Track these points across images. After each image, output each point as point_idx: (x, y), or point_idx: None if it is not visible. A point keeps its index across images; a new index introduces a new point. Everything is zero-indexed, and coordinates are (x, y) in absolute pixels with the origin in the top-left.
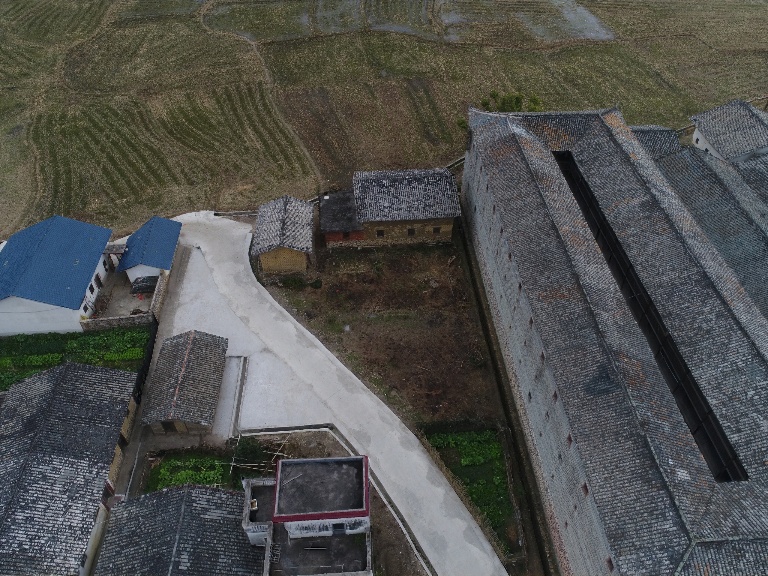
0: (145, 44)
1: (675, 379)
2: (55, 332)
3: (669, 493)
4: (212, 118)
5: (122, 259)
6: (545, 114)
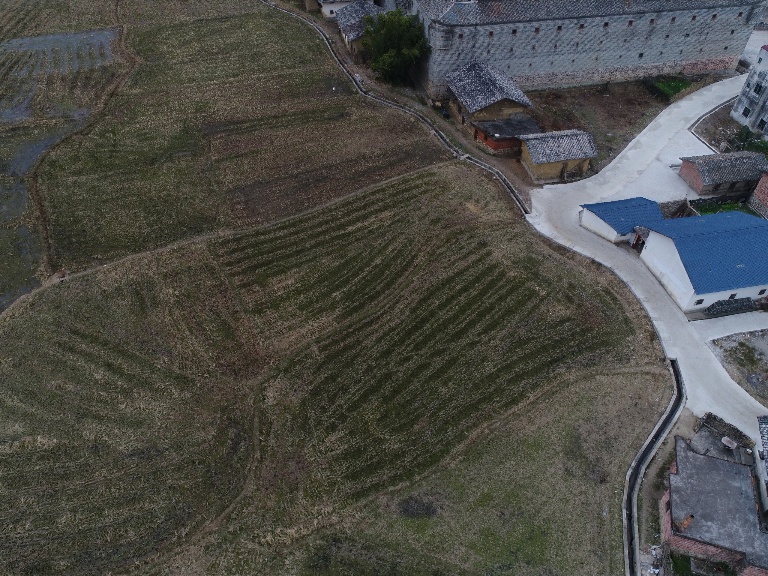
0: (5, 451)
1: None
2: None
3: None
4: (328, 266)
5: None
6: None
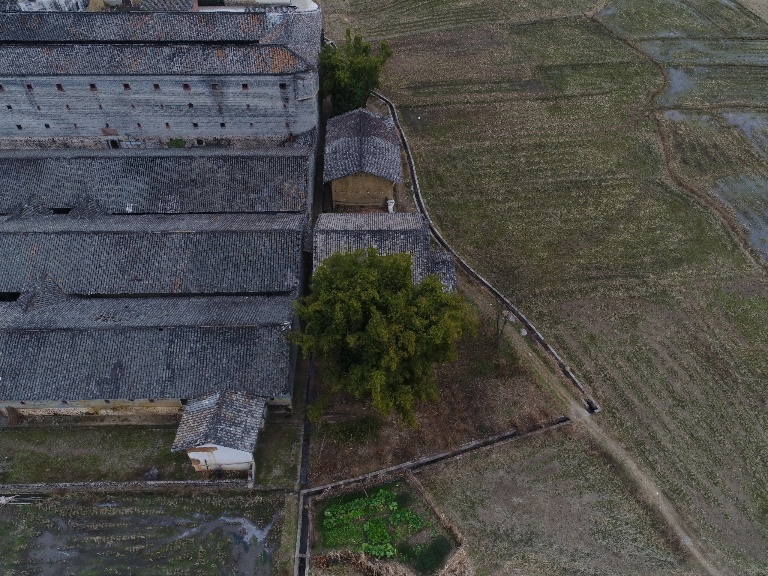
0: None
1: None
2: None
3: None
4: (441, 6)
5: None
6: None
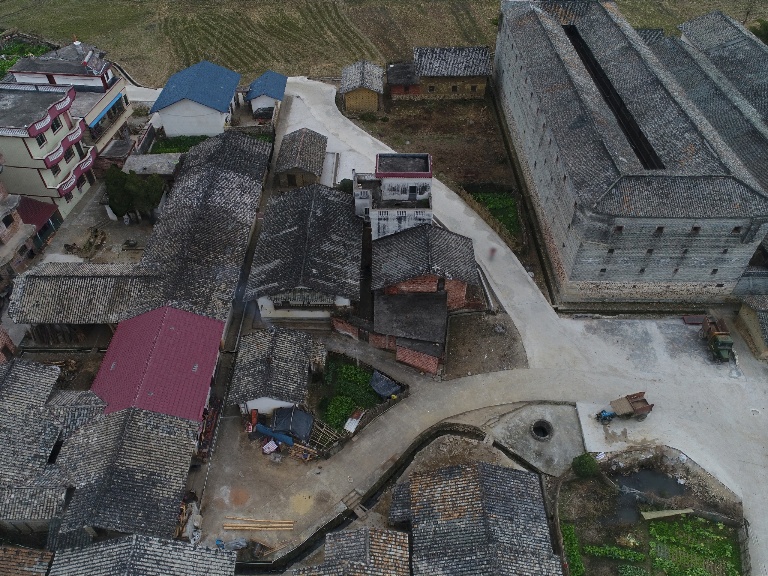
0: None
1: (633, 147)
2: (206, 135)
3: (612, 160)
4: (298, 24)
5: (248, 94)
6: (558, 0)
